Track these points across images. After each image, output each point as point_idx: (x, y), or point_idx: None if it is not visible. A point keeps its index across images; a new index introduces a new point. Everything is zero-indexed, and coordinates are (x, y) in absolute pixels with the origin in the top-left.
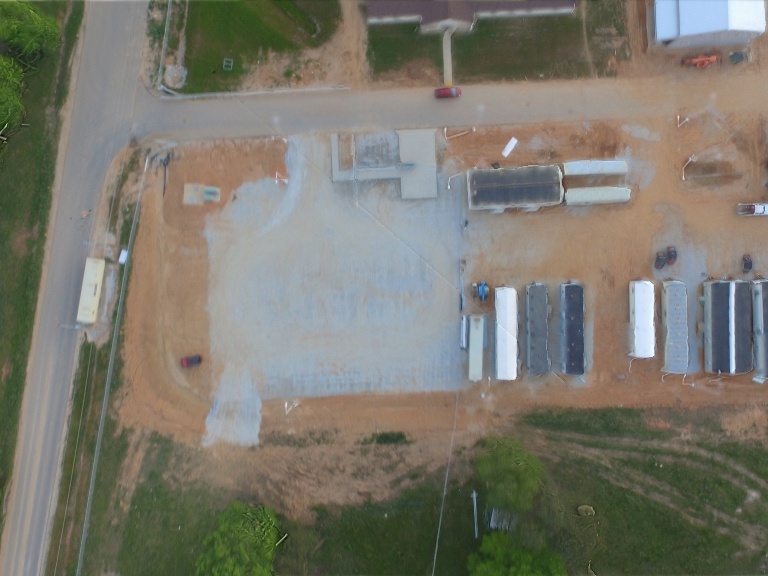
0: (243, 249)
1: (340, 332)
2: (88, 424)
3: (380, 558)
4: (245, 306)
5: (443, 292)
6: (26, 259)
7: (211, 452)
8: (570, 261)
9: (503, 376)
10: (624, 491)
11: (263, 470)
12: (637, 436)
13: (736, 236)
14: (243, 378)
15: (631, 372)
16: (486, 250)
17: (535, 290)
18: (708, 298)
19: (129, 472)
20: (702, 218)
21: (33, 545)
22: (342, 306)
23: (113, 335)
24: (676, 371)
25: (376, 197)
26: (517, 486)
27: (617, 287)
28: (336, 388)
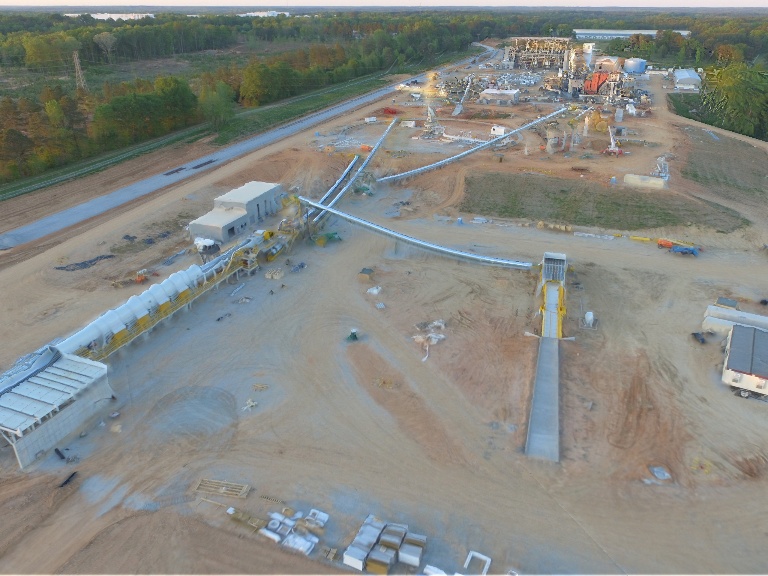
0: None
1: None
2: None
3: None
4: None
5: None
6: None
7: None
8: None
9: None
10: None
11: None
12: None
13: None
14: None
15: None
16: None
17: None
18: None
19: None
20: None
21: None
22: None
23: None
24: None
25: None
26: None
27: None
28: None
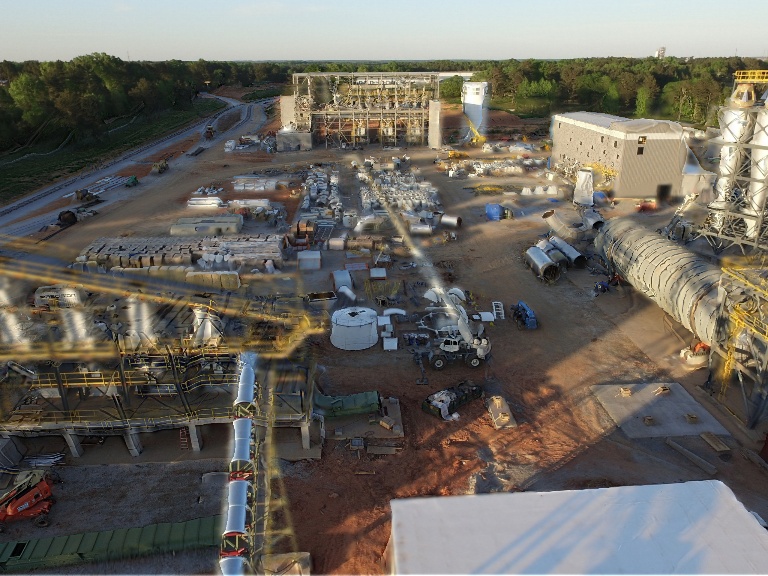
0: None
1: None
2: None
3: None
4: None
5: None
6: None
7: None
8: None
9: None
10: None
11: None
12: None
13: None
14: None
15: None
16: None
17: None
18: None
19: None
20: None
21: None
22: None
23: None
24: None
25: None
26: None
27: None
28: None
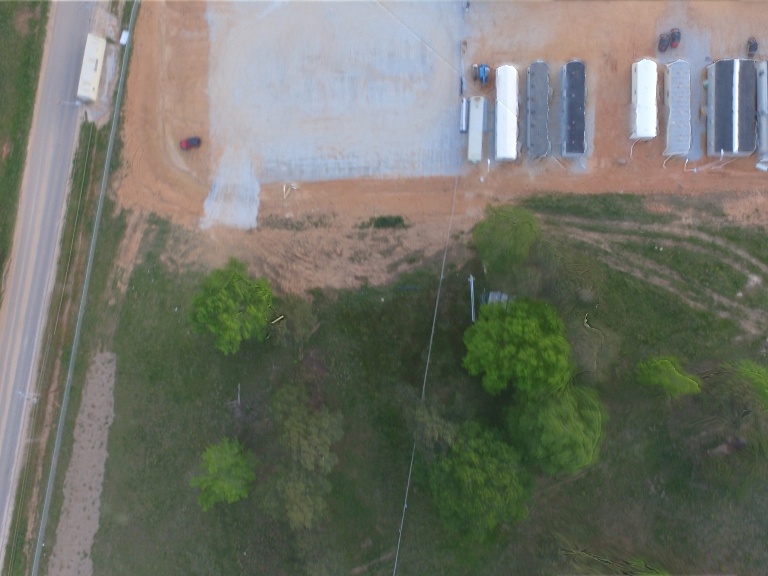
0: (244, 31)
1: (339, 115)
2: (87, 204)
3: (376, 341)
4: (245, 89)
5: (443, 75)
6: (28, 38)
7: (209, 234)
8: (572, 44)
9: (502, 154)
10: (623, 275)
11: (260, 253)
12: (637, 220)
13: (741, 20)
14: (242, 161)
15: (632, 158)
16: (487, 33)
17: (536, 67)
18: (712, 78)
19: (127, 253)
20: (707, 1)
21: (31, 320)
22: (342, 89)
23: (113, 116)
24: (678, 151)
25: None
26: (514, 242)
27: (619, 71)
28: (335, 172)
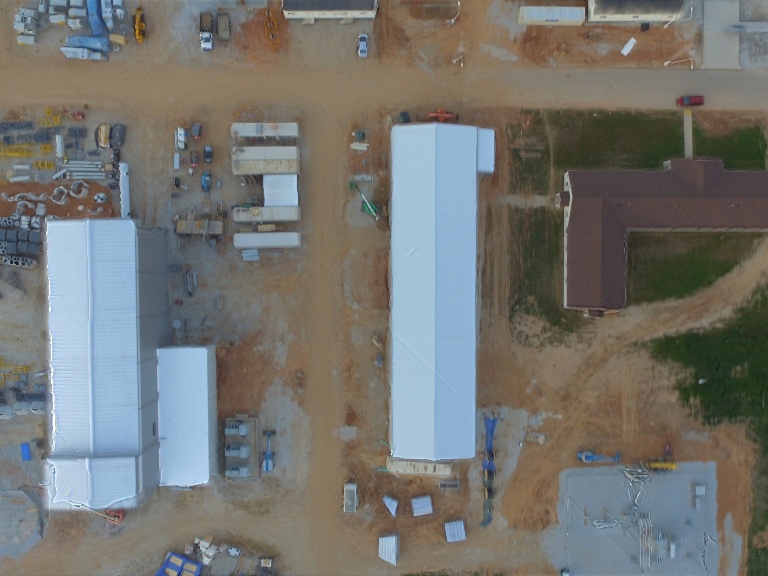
0: None
1: None
2: None
3: None
4: None
5: None
6: None
7: None
8: None
9: None
10: None
11: None
12: None
13: None
14: None
15: None
16: None
17: None
18: None
19: None
20: None
21: None
22: None
23: None
24: None
25: (765, 4)
26: None
27: None
28: None
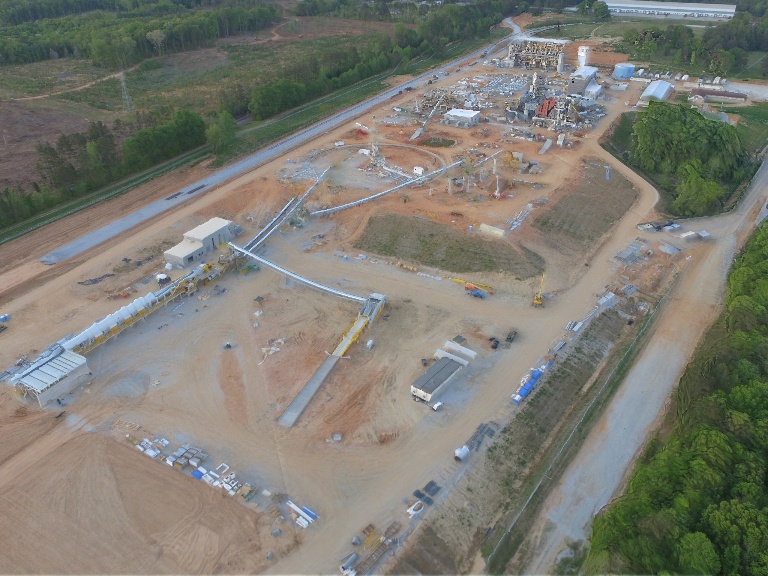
0: None
1: None
2: None
3: None
4: None
5: None
6: None
7: None
8: None
9: None
10: None
11: None
12: None
13: None
14: None
15: None
16: None
17: None
18: None
19: None
20: None
21: None
22: None
23: None
24: None
25: None
26: None
27: None
28: None
